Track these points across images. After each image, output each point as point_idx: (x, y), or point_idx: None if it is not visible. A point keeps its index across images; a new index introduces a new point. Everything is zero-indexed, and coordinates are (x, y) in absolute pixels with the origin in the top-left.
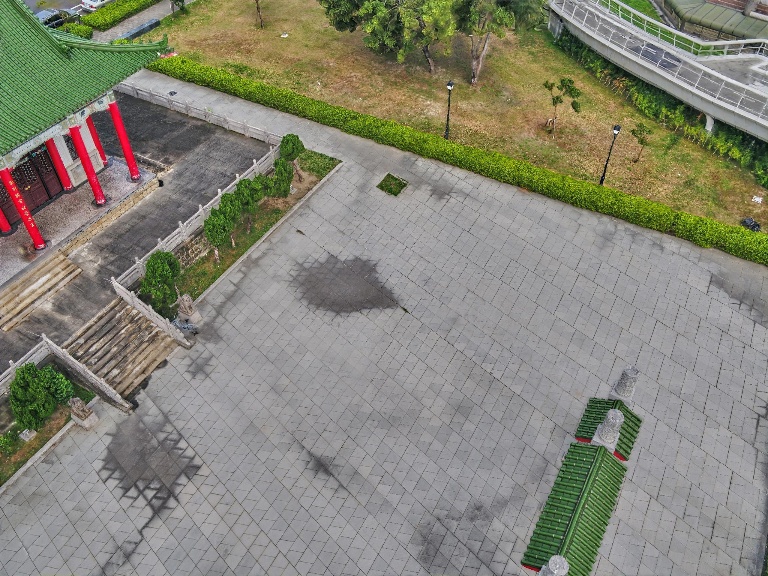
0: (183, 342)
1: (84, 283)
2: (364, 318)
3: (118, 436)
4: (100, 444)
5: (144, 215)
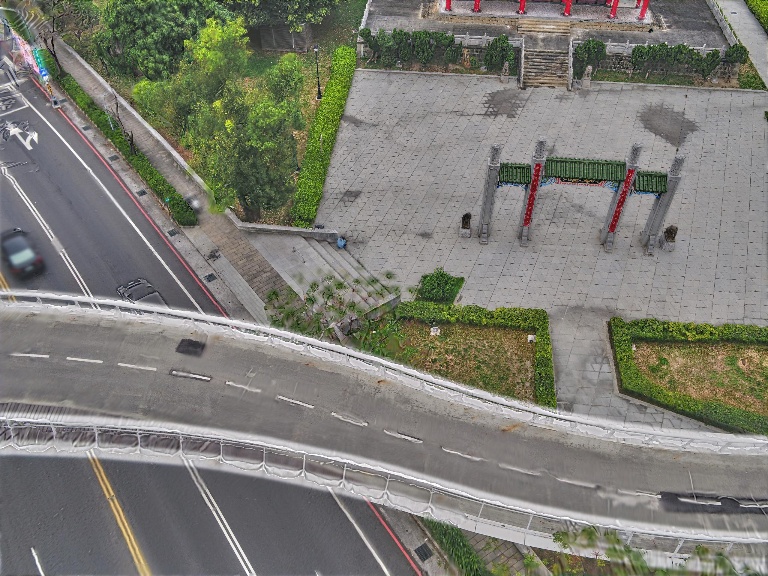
0: (569, 86)
1: (564, 39)
2: (653, 137)
3: (506, 91)
4: (498, 88)
5: (624, 36)
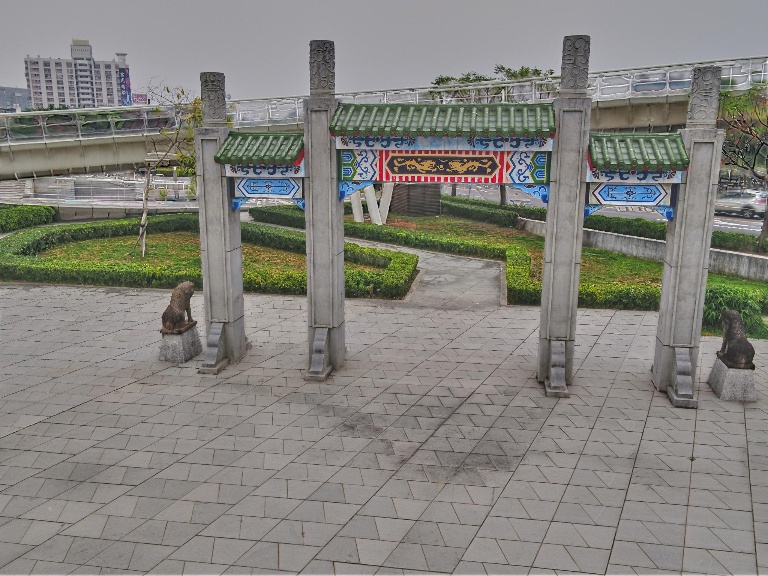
0: None
1: None
2: None
3: None
4: None
5: None
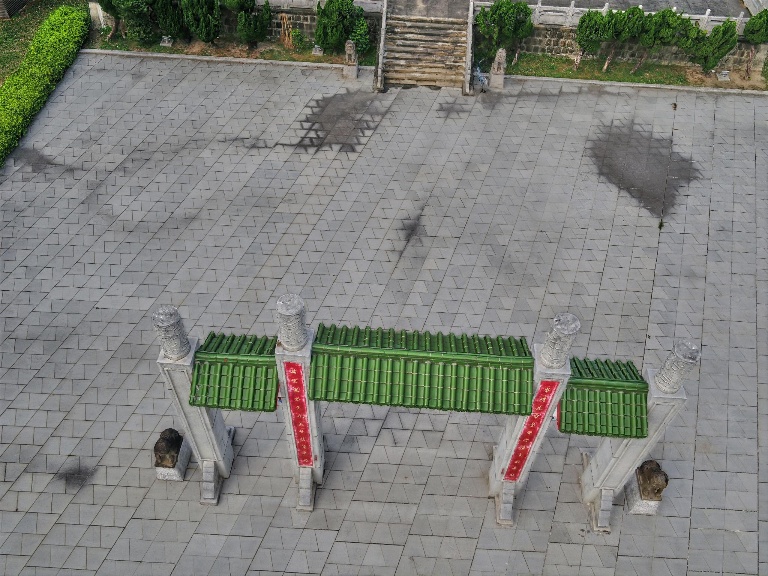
0: (466, 86)
1: None
2: (615, 196)
3: (350, 95)
4: (336, 89)
5: None
